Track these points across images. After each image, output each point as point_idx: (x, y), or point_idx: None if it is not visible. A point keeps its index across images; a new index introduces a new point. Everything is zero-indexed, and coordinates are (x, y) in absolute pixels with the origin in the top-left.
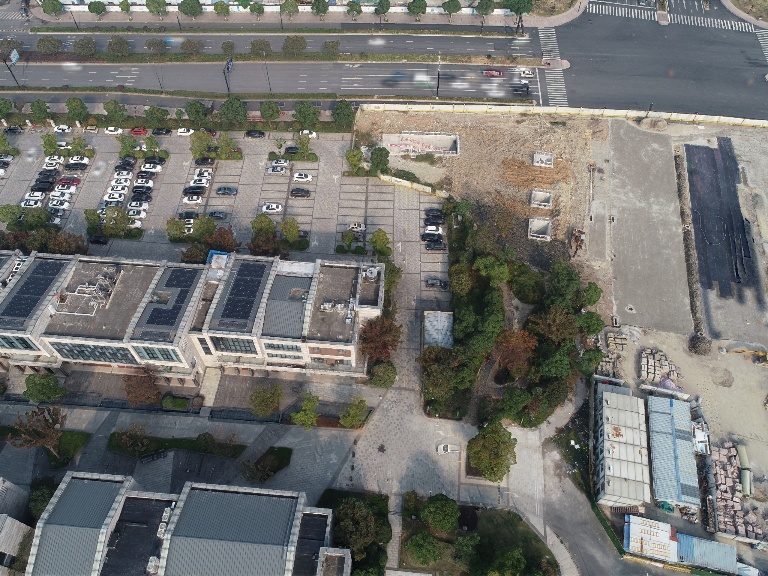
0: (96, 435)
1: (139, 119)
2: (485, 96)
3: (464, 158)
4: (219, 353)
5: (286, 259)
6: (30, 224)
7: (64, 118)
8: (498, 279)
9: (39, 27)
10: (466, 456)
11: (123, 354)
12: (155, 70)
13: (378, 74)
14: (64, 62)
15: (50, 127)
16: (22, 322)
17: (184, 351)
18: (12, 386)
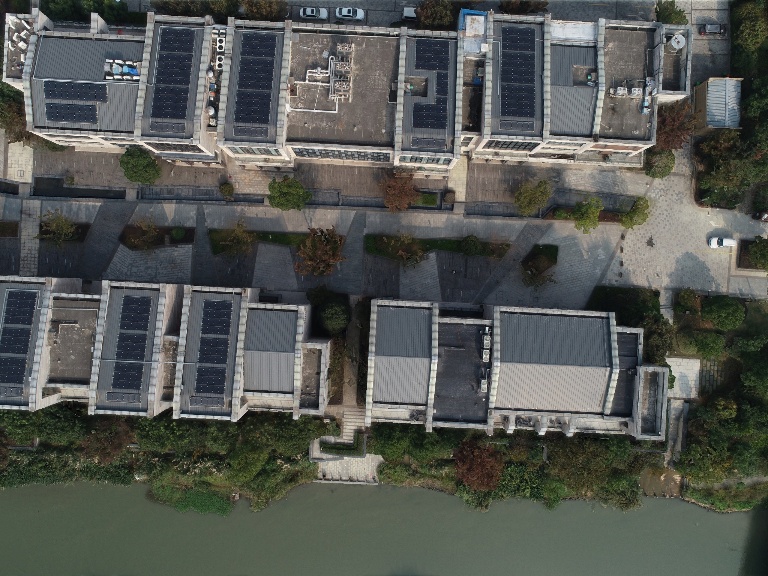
0: (349, 237)
1: None
2: None
3: None
4: (483, 149)
5: None
6: None
7: None
8: None
9: None
10: (738, 248)
11: (375, 156)
12: None
13: None
14: None
15: None
16: (265, 131)
17: None
18: (237, 184)
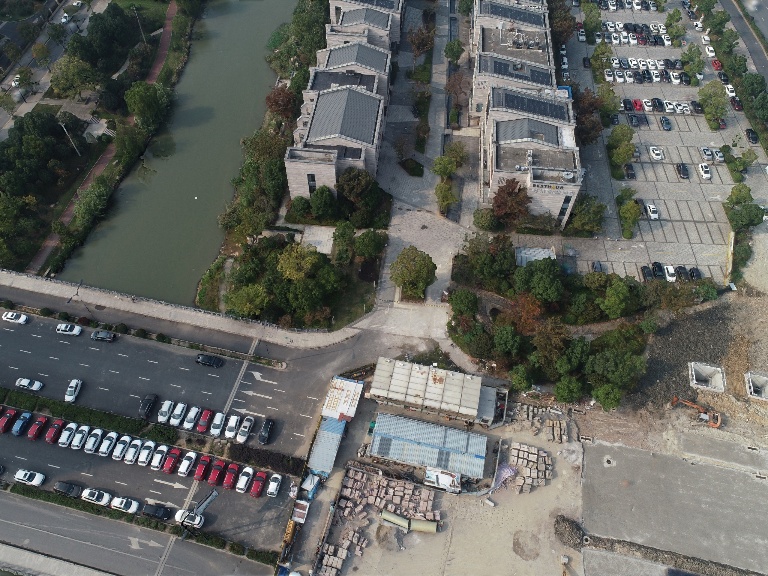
0: None
1: None
2: None
3: None
4: None
5: (584, 145)
6: None
7: None
8: (604, 302)
9: None
10: None
11: None
12: None
13: None
14: None
15: (698, 21)
16: (487, 12)
17: (479, 88)
18: None
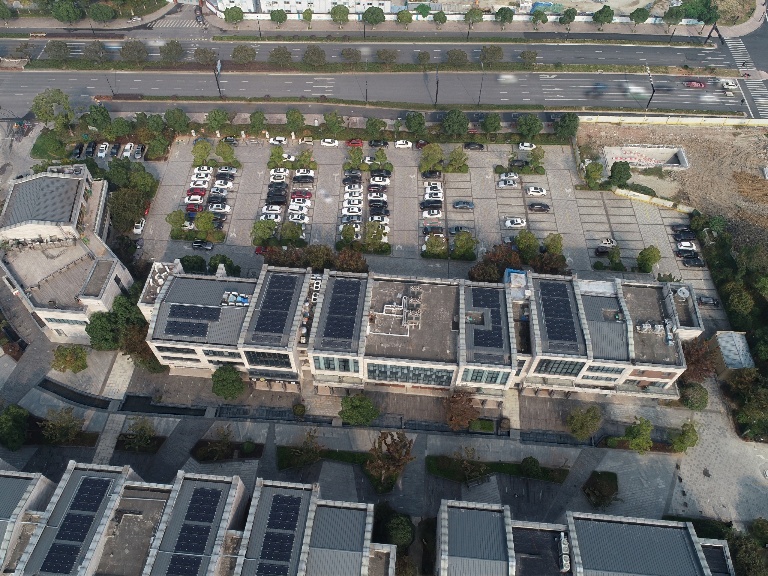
0: None
1: (352, 130)
2: (693, 108)
3: (693, 172)
4: (534, 375)
5: None
6: (276, 239)
7: (277, 129)
8: None
9: (219, 35)
10: None
11: (439, 376)
12: (350, 80)
13: (578, 85)
14: (257, 72)
15: (263, 138)
16: (349, 344)
17: None
18: (309, 407)
